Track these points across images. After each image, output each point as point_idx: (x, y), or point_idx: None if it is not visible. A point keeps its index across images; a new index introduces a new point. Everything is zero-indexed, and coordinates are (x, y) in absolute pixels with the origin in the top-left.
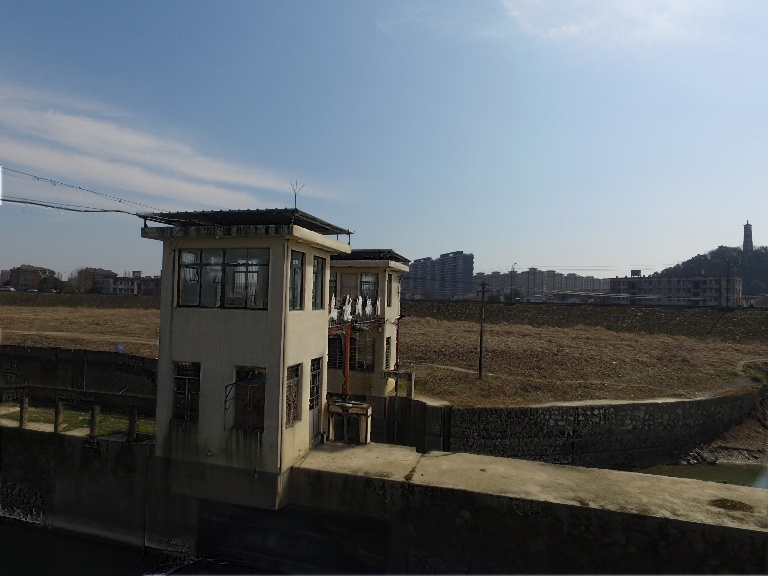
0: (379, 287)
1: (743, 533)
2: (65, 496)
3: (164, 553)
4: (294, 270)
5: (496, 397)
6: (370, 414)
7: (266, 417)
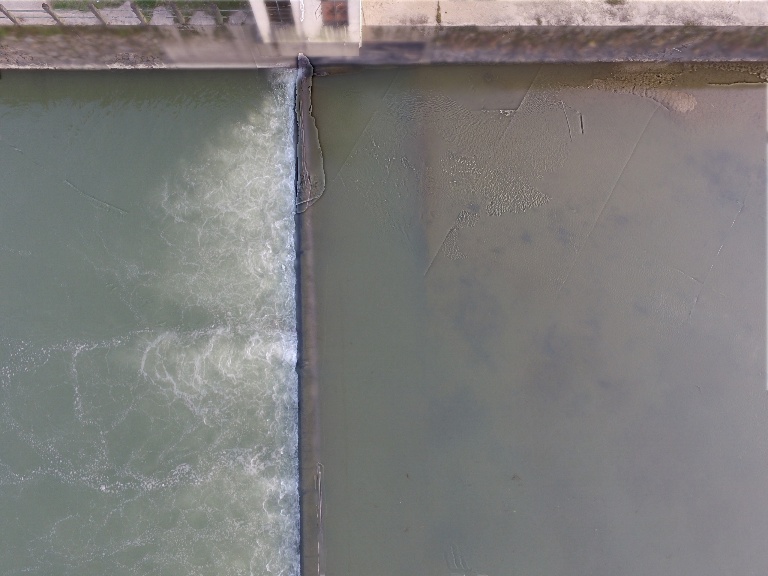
0: None
1: (611, 27)
2: (179, 55)
3: (273, 69)
4: None
5: None
6: None
7: (350, 19)
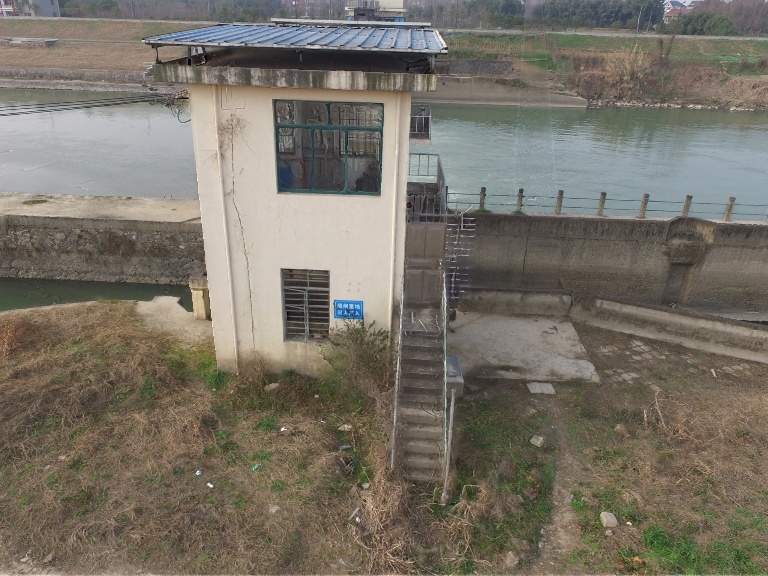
0: None
1: None
2: None
3: None
4: None
5: None
6: None
7: None
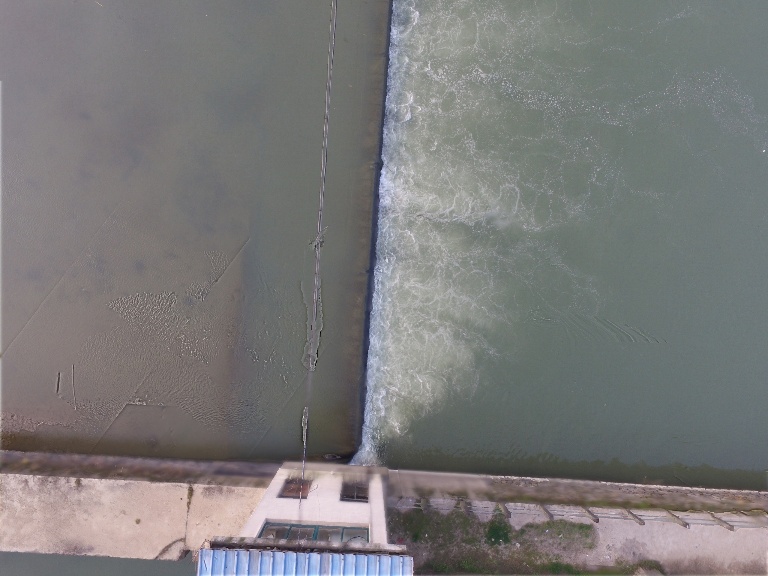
0: None
1: None
2: None
3: None
4: None
5: None
6: None
7: None
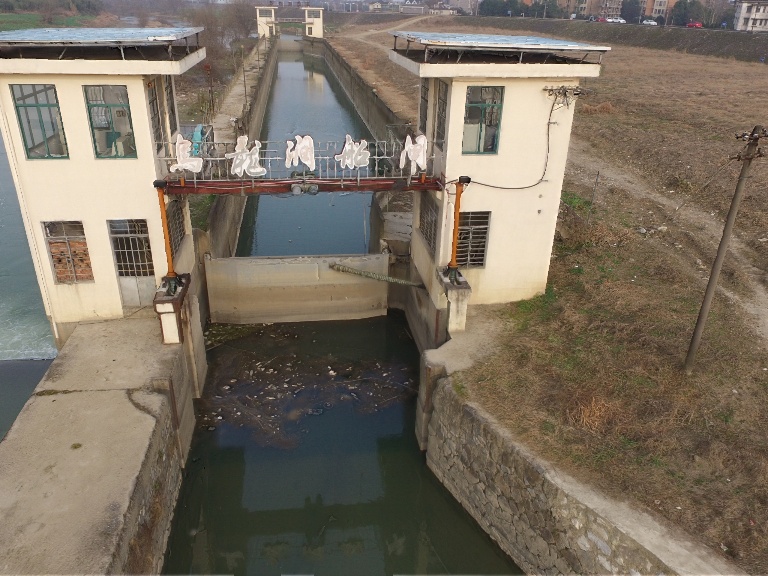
0: (446, 114)
1: None
2: None
3: None
4: (38, 108)
5: (557, 414)
6: (169, 311)
7: None
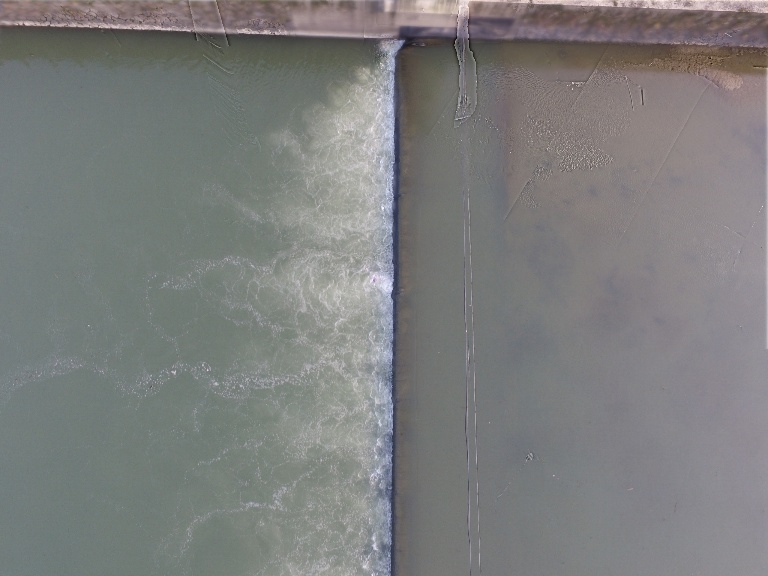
0: None
1: None
2: (302, 22)
3: (377, 39)
4: None
5: None
6: None
7: None
